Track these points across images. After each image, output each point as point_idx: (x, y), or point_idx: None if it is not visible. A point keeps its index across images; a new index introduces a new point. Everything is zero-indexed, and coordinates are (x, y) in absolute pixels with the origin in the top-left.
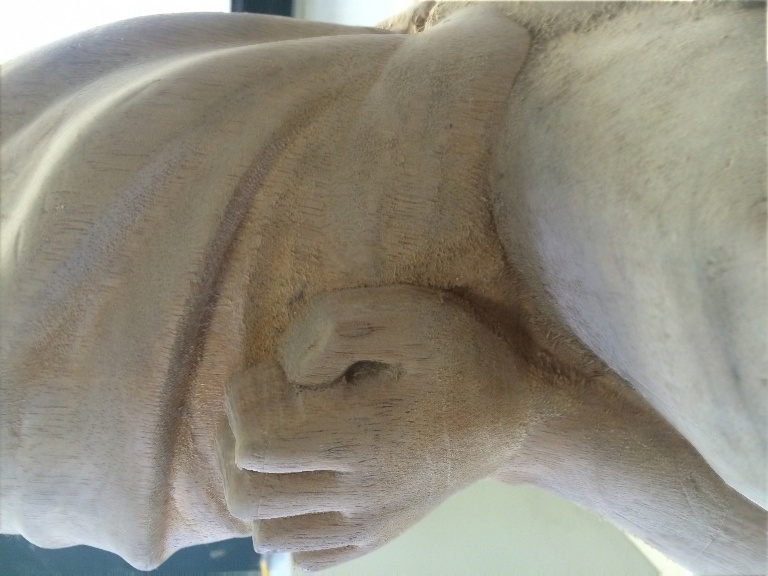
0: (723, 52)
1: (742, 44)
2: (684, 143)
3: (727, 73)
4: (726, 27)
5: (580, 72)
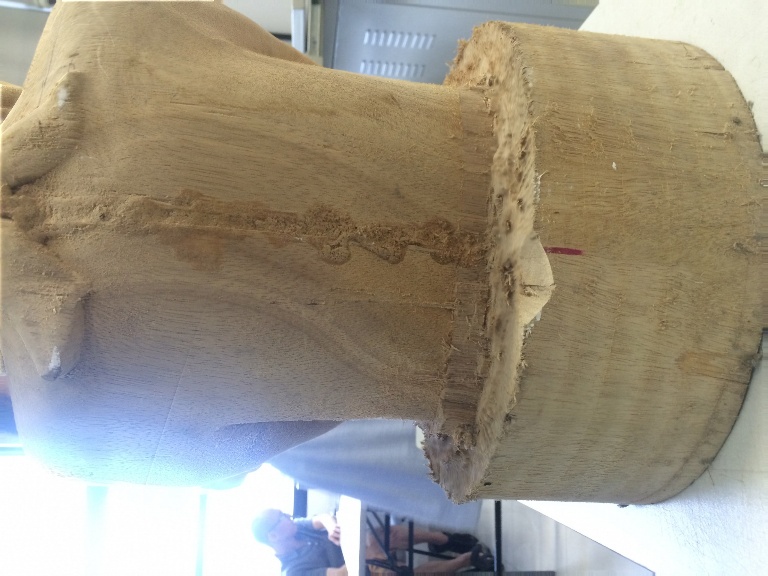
0: (36, 396)
1: (42, 399)
2: (18, 422)
3: (34, 408)
4: (41, 384)
5: (2, 336)
